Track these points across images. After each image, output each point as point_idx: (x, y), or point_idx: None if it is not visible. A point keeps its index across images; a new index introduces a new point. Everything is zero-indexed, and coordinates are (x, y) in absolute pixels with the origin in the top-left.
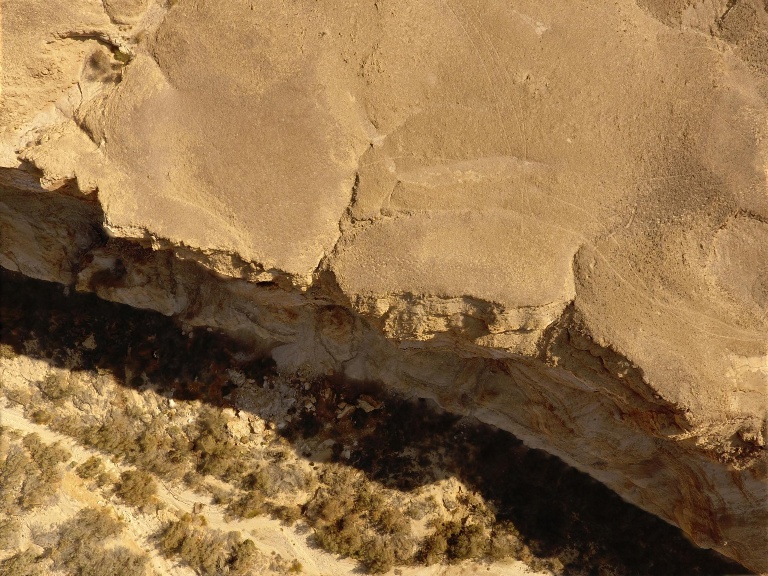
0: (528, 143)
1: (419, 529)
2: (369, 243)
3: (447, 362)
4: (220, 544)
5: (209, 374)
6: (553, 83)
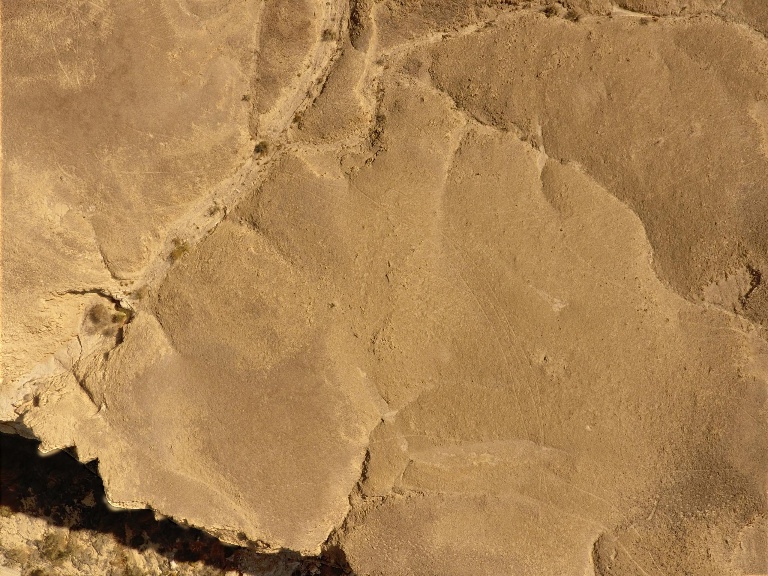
0: (546, 429)
1: None
2: (380, 524)
3: None
4: None
5: None
6: (571, 366)
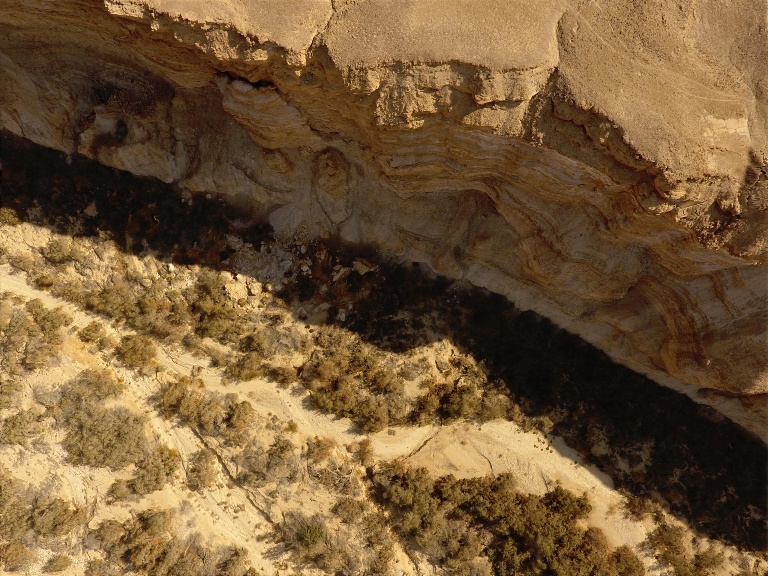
0: None
1: (412, 389)
2: (360, 15)
3: (439, 208)
4: (218, 403)
5: (208, 239)
6: None
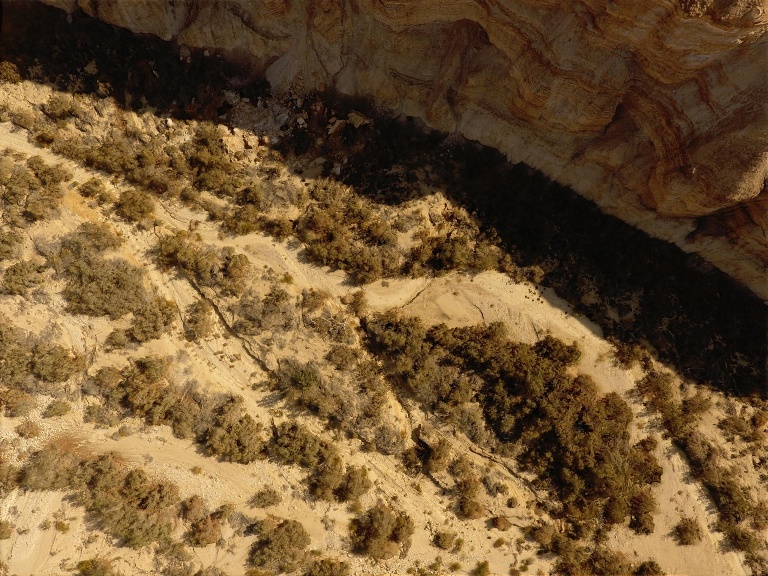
0: None
1: (406, 241)
2: None
3: (432, 43)
4: (215, 254)
5: (205, 95)
6: None
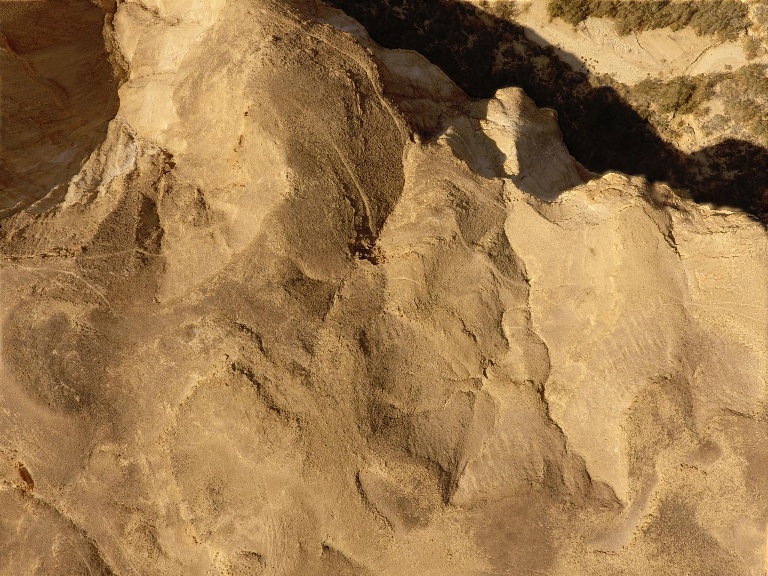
0: None
1: (716, 106)
2: None
3: None
4: None
5: None
6: None
